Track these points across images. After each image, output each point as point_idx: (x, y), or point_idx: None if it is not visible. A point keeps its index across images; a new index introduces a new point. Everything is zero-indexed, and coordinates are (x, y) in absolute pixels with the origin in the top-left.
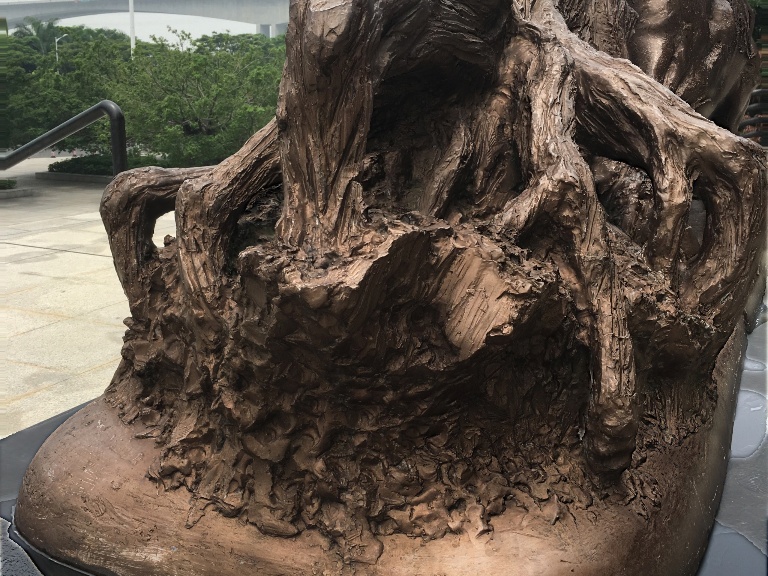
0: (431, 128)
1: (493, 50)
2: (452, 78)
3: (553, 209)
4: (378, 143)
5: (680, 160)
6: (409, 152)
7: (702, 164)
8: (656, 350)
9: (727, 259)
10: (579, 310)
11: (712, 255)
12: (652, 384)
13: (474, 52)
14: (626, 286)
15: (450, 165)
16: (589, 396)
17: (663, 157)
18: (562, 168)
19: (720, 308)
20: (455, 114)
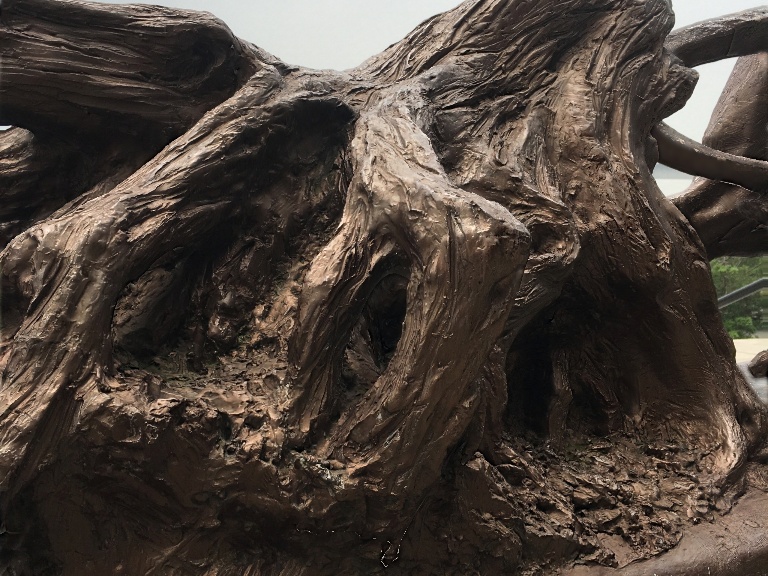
0: None
1: (199, 101)
2: (91, 130)
3: (12, 272)
4: (44, 212)
5: (365, 226)
6: None
7: (394, 231)
8: (222, 499)
9: (398, 375)
10: None
11: None
12: (254, 556)
13: (123, 98)
14: (123, 389)
15: None
16: (16, 541)
17: (342, 222)
18: None
19: (380, 453)
20: (111, 175)
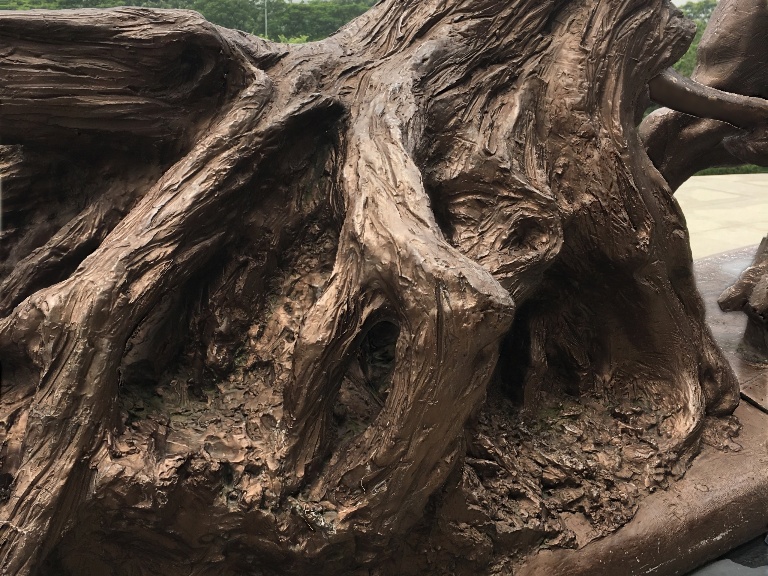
0: (82, 204)
1: (189, 109)
2: (82, 148)
3: (21, 340)
4: (38, 216)
5: (356, 278)
6: (49, 231)
7: (385, 288)
8: (226, 540)
9: (386, 432)
10: (12, 477)
11: (375, 421)
12: None
13: (113, 117)
14: (132, 453)
15: (35, 257)
16: None
17: (334, 271)
18: (54, 287)
19: (369, 499)
20: (104, 190)
